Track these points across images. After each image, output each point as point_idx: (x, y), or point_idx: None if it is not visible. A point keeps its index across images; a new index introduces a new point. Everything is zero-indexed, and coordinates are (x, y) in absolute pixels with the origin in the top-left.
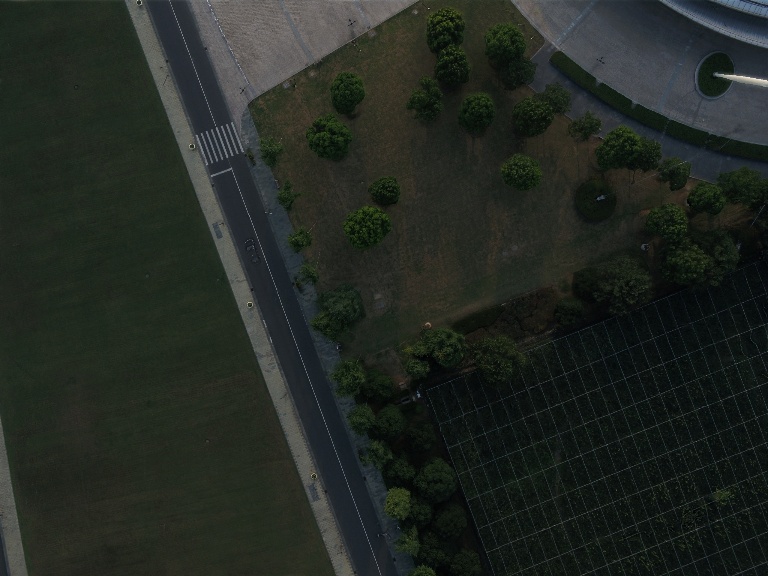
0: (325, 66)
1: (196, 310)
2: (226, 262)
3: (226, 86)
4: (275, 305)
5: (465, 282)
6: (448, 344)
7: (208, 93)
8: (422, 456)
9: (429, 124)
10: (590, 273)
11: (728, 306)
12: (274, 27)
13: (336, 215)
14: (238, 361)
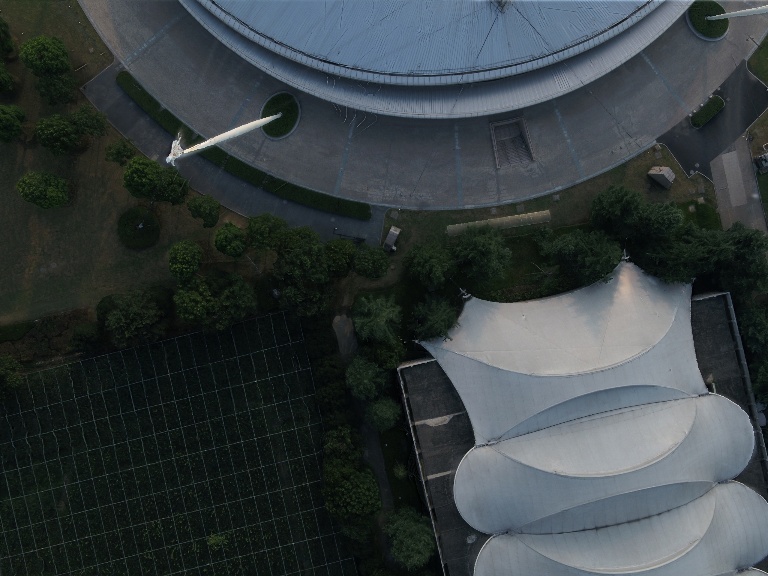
0: None
1: None
2: None
3: None
4: None
5: None
6: None
7: None
8: None
9: None
10: (110, 300)
11: (250, 351)
12: None
13: None
14: None
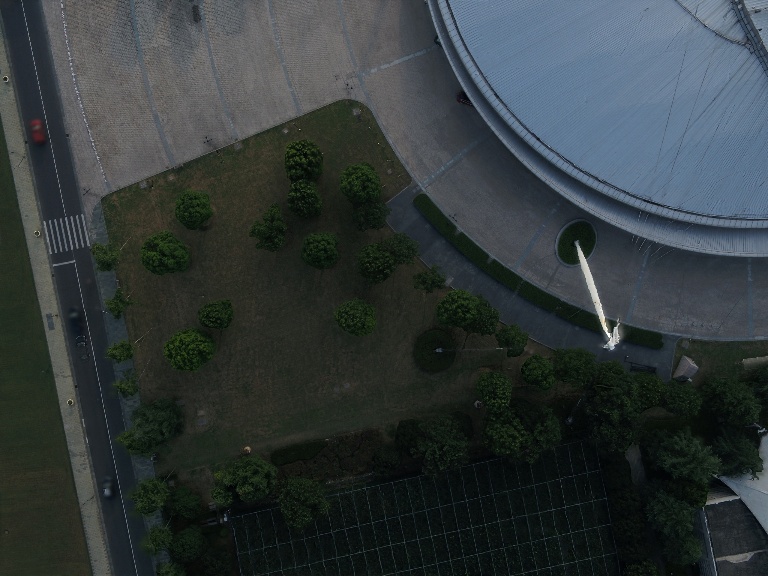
0: (185, 172)
1: (16, 399)
2: (54, 355)
3: (82, 177)
4: (97, 405)
5: (292, 412)
6: (250, 482)
7: (63, 181)
8: None
9: (280, 248)
10: (412, 427)
11: (547, 479)
12: (140, 124)
13: (171, 325)
14: (50, 456)
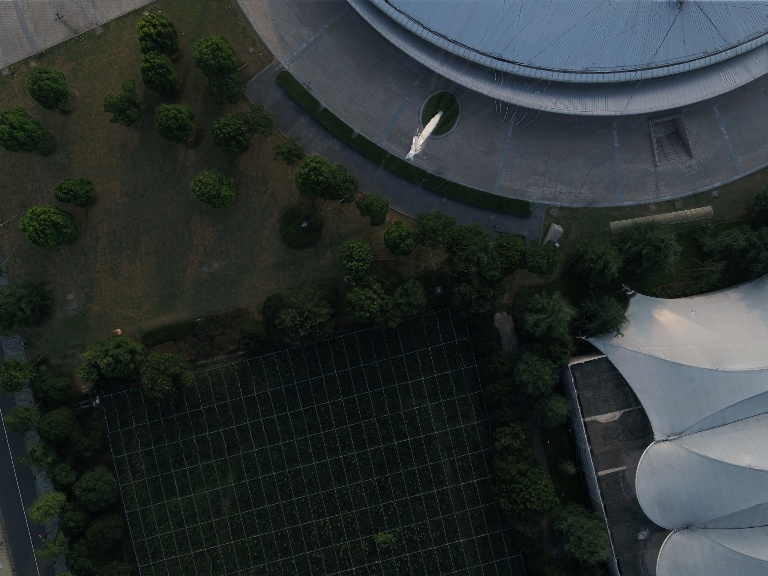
0: (47, 58)
1: None
2: None
3: None
4: None
5: (161, 293)
6: (110, 354)
7: None
8: (93, 462)
9: (143, 129)
10: (278, 299)
11: (416, 349)
12: (0, 12)
13: None
14: None
